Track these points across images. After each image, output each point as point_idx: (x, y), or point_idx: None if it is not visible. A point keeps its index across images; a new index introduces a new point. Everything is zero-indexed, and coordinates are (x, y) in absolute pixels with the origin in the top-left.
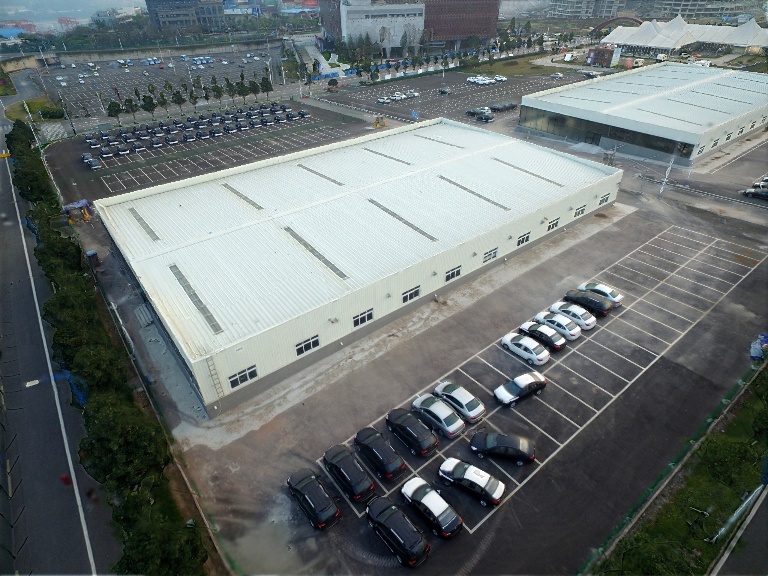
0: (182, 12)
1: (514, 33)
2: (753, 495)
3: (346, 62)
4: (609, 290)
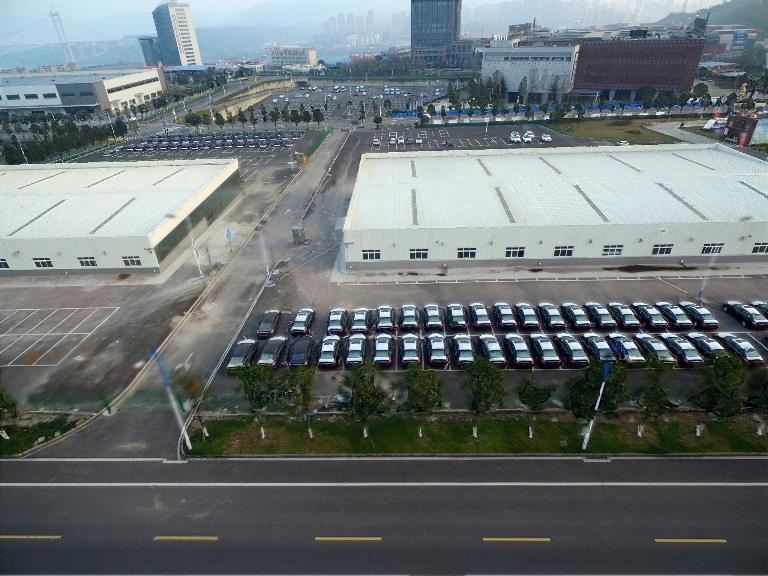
0: (433, 49)
1: (766, 87)
2: None
3: (472, 104)
4: None
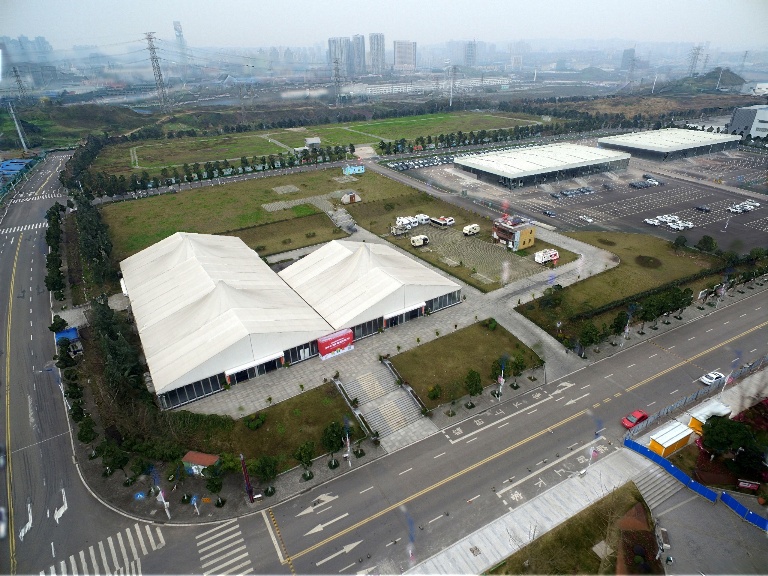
0: None
1: None
2: (597, 134)
3: None
4: None
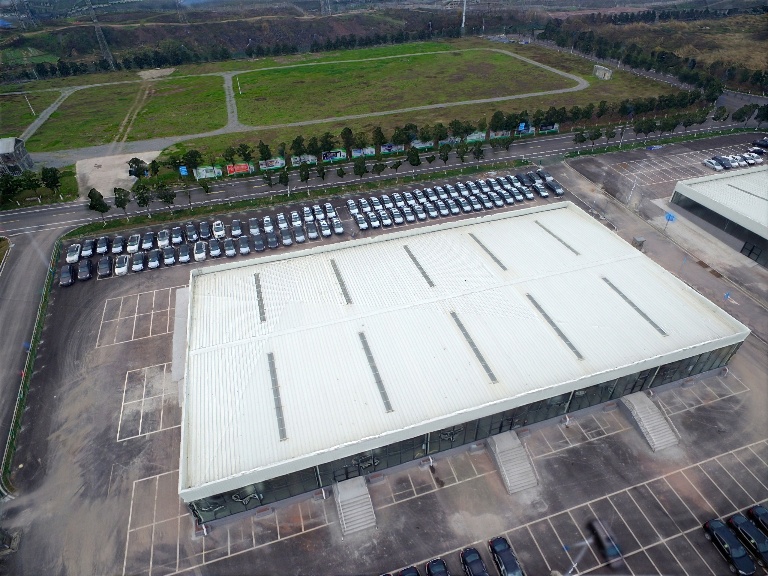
0: None
1: None
2: None
3: None
4: (711, 160)
